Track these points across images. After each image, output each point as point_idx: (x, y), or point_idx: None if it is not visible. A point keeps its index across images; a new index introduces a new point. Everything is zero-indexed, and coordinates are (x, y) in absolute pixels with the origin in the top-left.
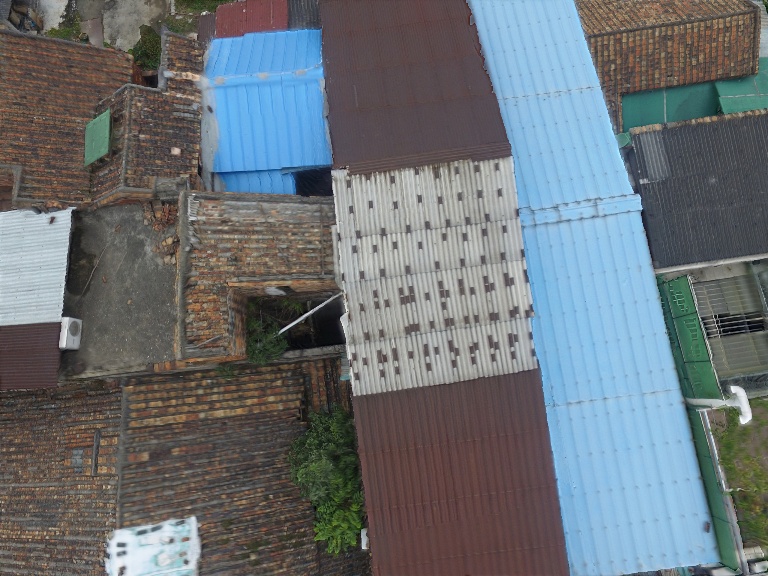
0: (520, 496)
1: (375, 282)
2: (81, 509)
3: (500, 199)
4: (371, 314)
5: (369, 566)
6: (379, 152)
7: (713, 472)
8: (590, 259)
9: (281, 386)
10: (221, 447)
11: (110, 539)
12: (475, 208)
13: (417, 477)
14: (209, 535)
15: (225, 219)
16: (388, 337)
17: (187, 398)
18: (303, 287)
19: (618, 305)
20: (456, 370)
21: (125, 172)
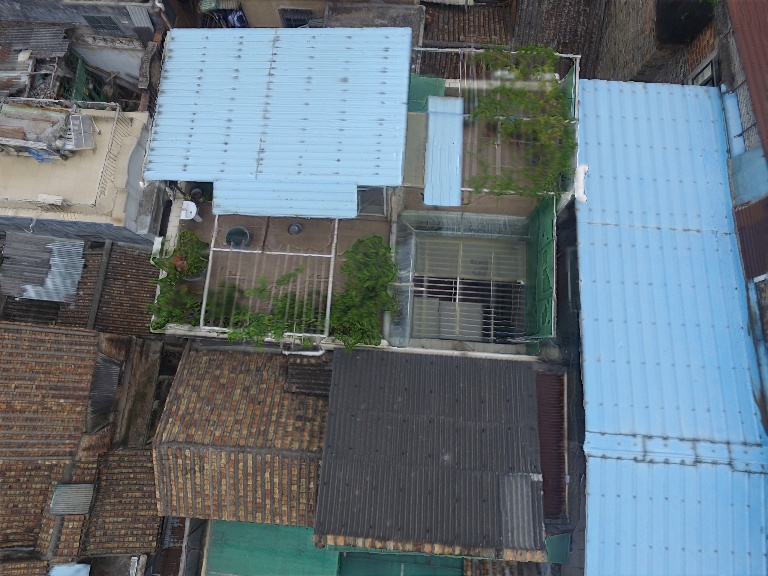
0: None
1: None
2: None
3: None
4: None
5: None
6: None
7: None
8: (660, 383)
9: None
10: None
11: None
12: None
13: None
14: None
15: None
16: None
17: None
18: None
19: (633, 321)
20: None
21: None
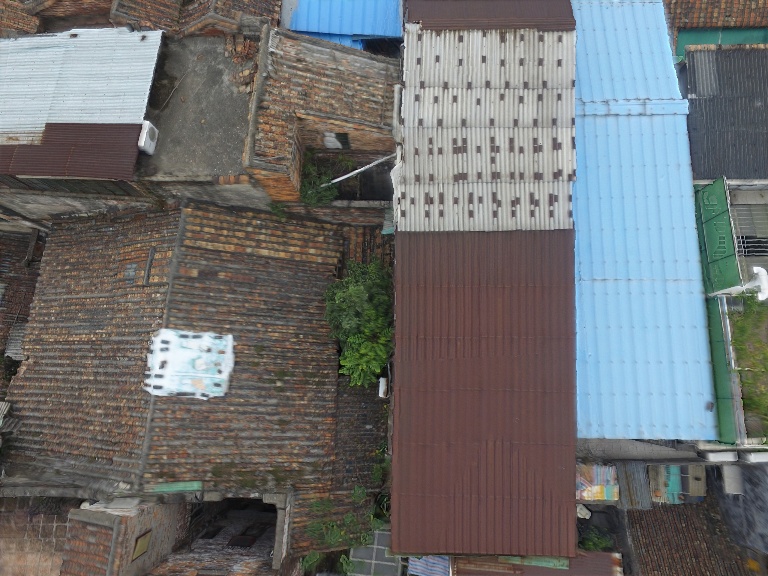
0: (540, 343)
1: (432, 130)
2: (129, 314)
3: (559, 69)
4: (424, 159)
5: (381, 420)
6: (451, 14)
7: (724, 354)
8: (632, 152)
9: (322, 242)
10: (262, 282)
11: (155, 336)
12: (534, 74)
13: (446, 313)
14: (242, 355)
15: (300, 58)
16: (437, 181)
17: (237, 232)
18: (360, 140)
19: (653, 197)
20: (496, 220)
21: (216, 2)
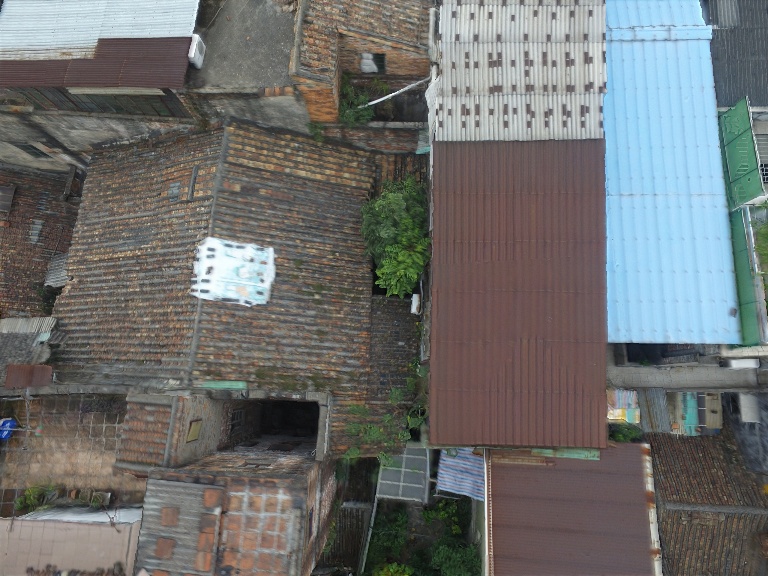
0: (572, 247)
1: (468, 45)
2: (174, 228)
3: None
4: (461, 72)
5: (413, 338)
6: None
7: (747, 262)
8: (658, 75)
9: (356, 167)
10: (300, 201)
11: (202, 244)
12: None
13: (482, 219)
14: (282, 268)
15: None
16: (473, 94)
17: (277, 152)
18: (396, 62)
19: (678, 117)
20: (530, 130)
21: None
